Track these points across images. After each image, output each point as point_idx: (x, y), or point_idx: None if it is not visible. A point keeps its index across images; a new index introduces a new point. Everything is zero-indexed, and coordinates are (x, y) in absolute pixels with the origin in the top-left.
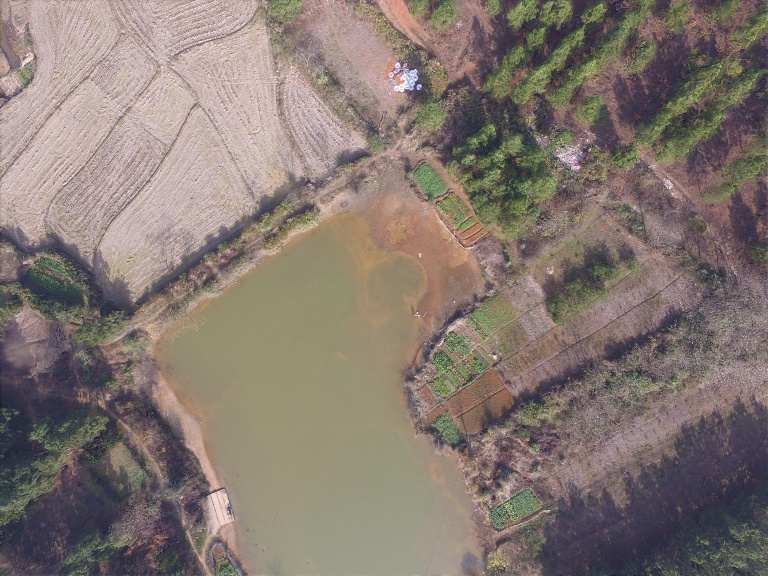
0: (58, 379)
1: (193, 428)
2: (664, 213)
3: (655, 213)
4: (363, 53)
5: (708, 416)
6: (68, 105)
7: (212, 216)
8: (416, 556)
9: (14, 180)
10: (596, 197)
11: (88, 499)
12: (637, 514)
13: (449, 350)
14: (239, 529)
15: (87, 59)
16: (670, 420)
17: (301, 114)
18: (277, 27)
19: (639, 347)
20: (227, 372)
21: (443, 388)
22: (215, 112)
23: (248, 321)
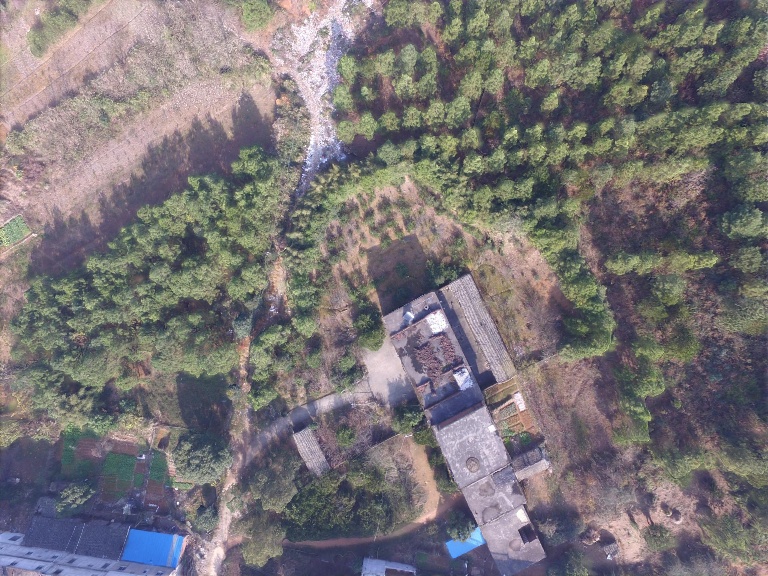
0: None
1: None
2: None
3: None
4: None
5: (170, 135)
6: None
7: None
8: None
9: None
10: None
11: None
12: (110, 231)
13: None
14: None
15: None
16: (138, 141)
17: None
18: None
19: (106, 72)
20: None
21: None
22: None
23: None
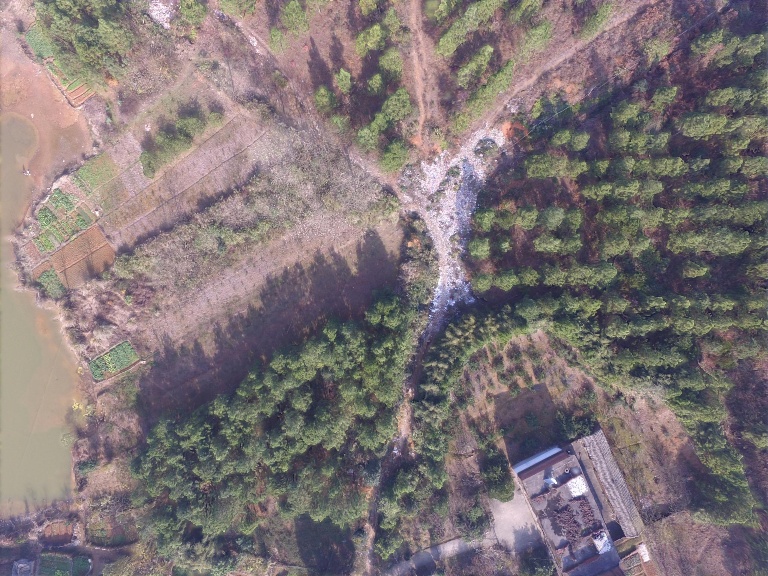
0: None
1: None
2: (245, 68)
3: (242, 69)
4: None
5: (291, 267)
6: None
7: None
8: (23, 409)
9: None
10: (184, 53)
11: None
12: (225, 363)
13: (53, 206)
14: None
15: None
16: (256, 271)
17: None
18: None
19: (224, 199)
20: None
21: (47, 244)
22: None
23: None
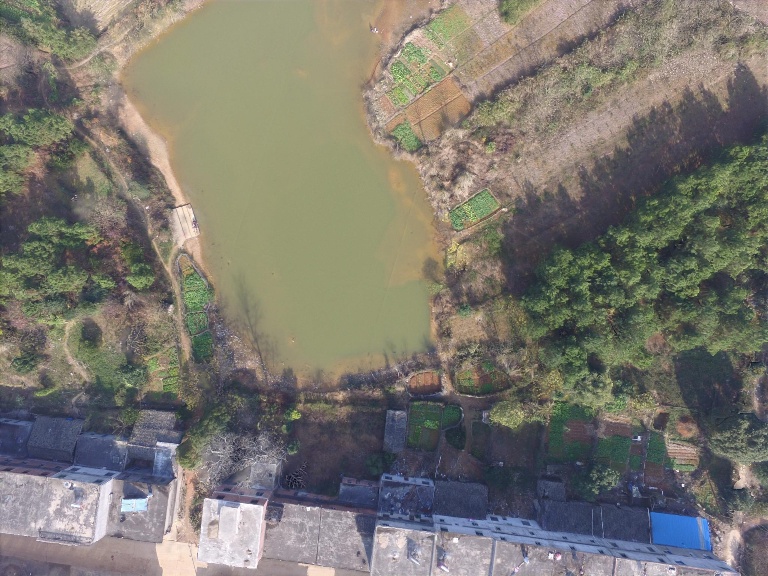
0: (26, 95)
1: (159, 147)
2: None
3: None
4: None
5: (658, 106)
6: None
7: None
8: (378, 263)
9: None
10: None
11: (55, 205)
12: (592, 206)
13: (406, 60)
14: (204, 243)
15: None
16: (622, 113)
17: None
18: None
19: (589, 41)
20: (191, 92)
21: (401, 97)
22: None
23: (211, 43)
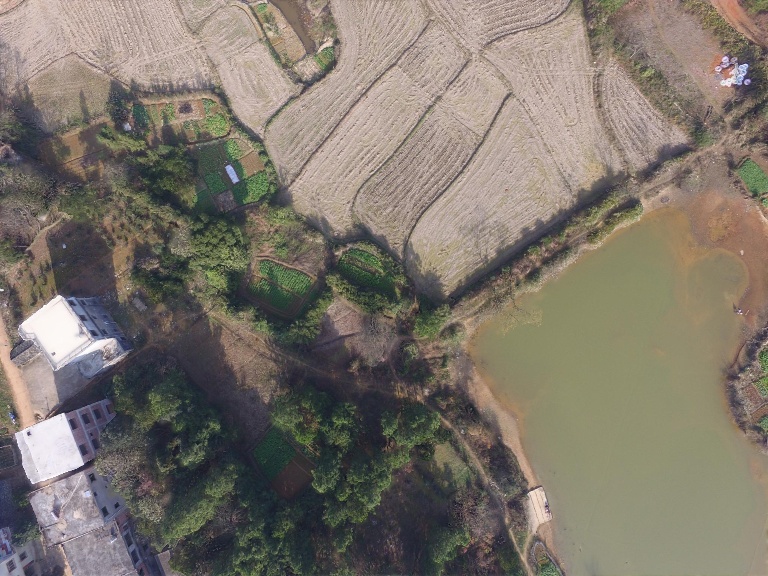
0: (381, 373)
1: (510, 425)
2: None
3: None
4: (689, 46)
5: None
6: (374, 92)
7: (528, 209)
8: (736, 556)
9: (318, 168)
10: None
11: (417, 496)
12: None
13: None
14: (556, 528)
15: (393, 45)
16: None
17: (620, 107)
18: (604, 17)
19: None
20: (544, 368)
21: None
22: (530, 103)
23: (566, 317)
